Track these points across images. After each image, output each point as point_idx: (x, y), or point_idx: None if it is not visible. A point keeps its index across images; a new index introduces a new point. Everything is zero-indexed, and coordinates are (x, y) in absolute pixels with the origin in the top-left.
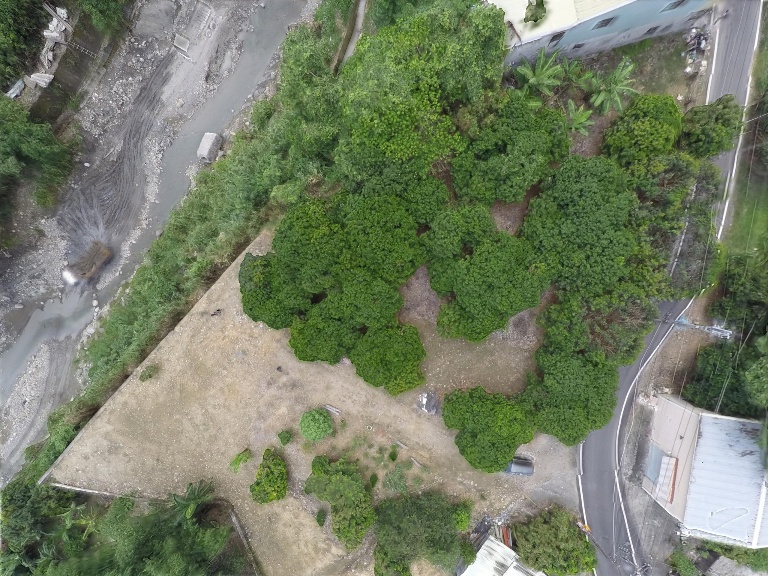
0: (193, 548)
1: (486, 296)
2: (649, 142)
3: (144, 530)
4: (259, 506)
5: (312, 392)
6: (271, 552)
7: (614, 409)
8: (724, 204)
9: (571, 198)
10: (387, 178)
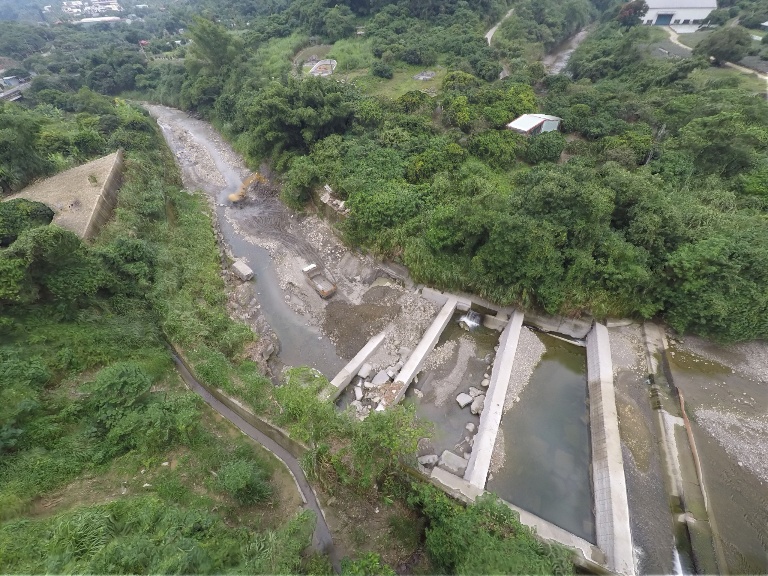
0: None
1: None
2: None
3: (7, 151)
4: None
5: None
6: None
7: None
8: None
9: None
10: None
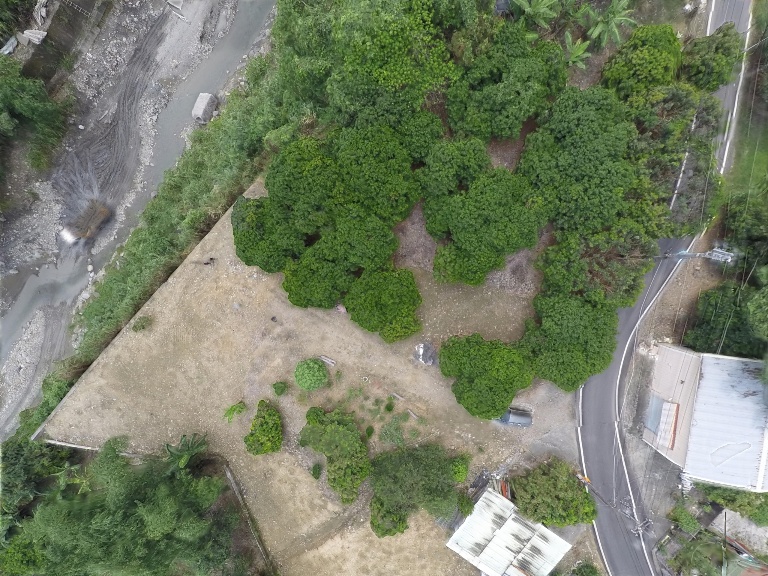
0: (186, 497)
1: (482, 232)
2: (648, 71)
3: (136, 477)
4: (254, 462)
5: (307, 343)
6: (266, 509)
7: (613, 352)
8: (725, 145)
9: (568, 128)
10: (380, 108)
